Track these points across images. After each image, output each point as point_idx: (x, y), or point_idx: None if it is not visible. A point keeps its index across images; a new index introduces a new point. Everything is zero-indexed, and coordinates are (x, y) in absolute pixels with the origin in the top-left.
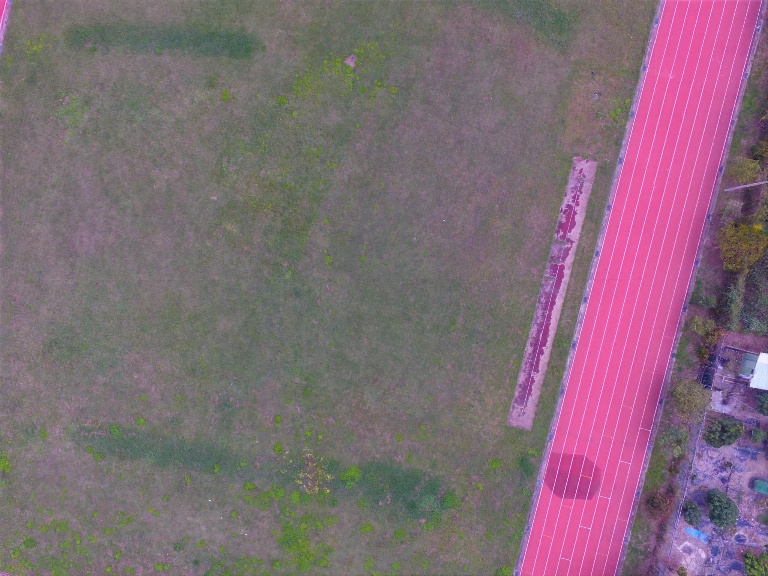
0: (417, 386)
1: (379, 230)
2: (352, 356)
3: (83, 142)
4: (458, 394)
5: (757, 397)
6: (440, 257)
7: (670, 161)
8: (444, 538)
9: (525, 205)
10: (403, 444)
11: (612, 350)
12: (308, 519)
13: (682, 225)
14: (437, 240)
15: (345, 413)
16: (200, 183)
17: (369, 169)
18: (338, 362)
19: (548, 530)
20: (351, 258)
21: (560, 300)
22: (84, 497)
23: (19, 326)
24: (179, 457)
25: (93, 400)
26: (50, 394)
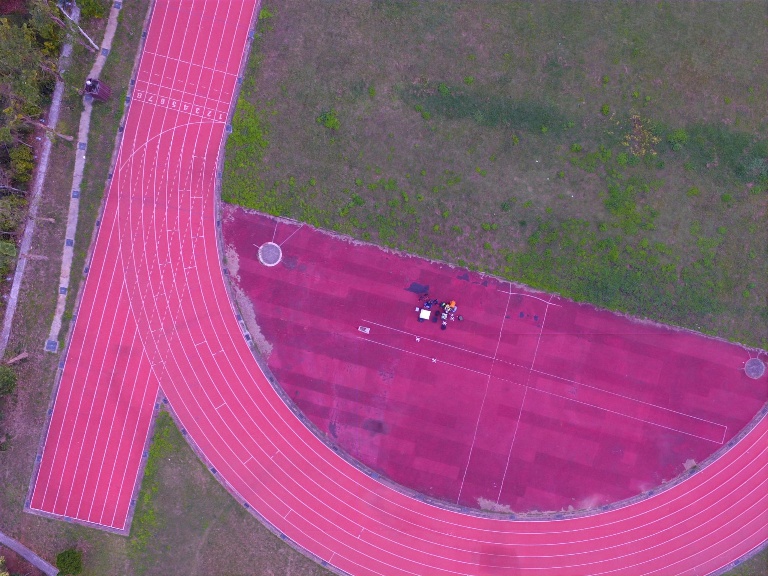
0: (745, 48)
1: None
2: (680, 17)
3: None
4: None
5: None
6: None
7: None
8: None
9: None
10: (730, 107)
11: None
12: (635, 181)
13: None
14: None
15: (672, 75)
16: None
17: None
18: (666, 23)
19: None
20: None
21: None
22: (412, 156)
23: None
24: (507, 116)
25: (422, 58)
26: (379, 51)
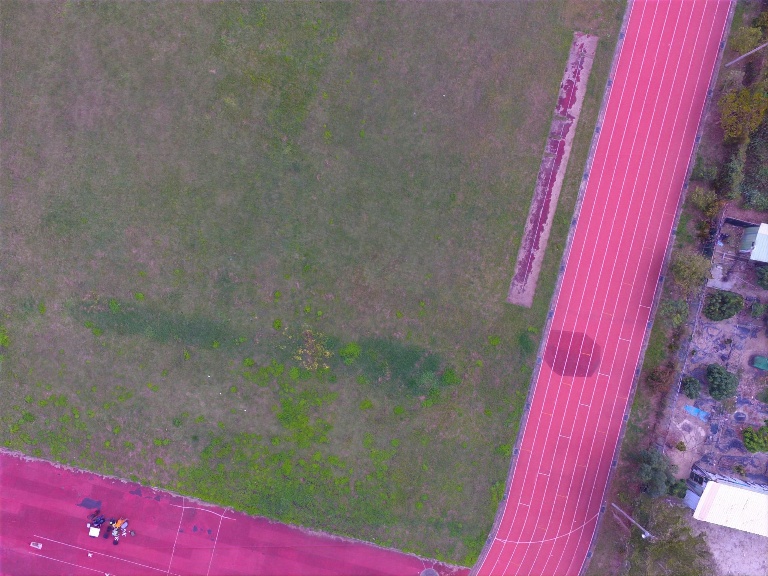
0: (417, 262)
1: (379, 105)
2: (351, 232)
3: (81, 13)
4: (458, 271)
5: (757, 270)
6: (440, 132)
7: (671, 36)
8: (443, 415)
9: (525, 80)
10: (402, 321)
11: (612, 227)
12: (307, 395)
13: (683, 101)
14: (437, 115)
15: (344, 289)
16: (199, 56)
17: (369, 43)
18: (337, 238)
19: (548, 407)
20: (351, 133)
21: (560, 176)
22: (83, 372)
23: (17, 199)
24: (178, 332)
25: (92, 274)
26: (48, 268)
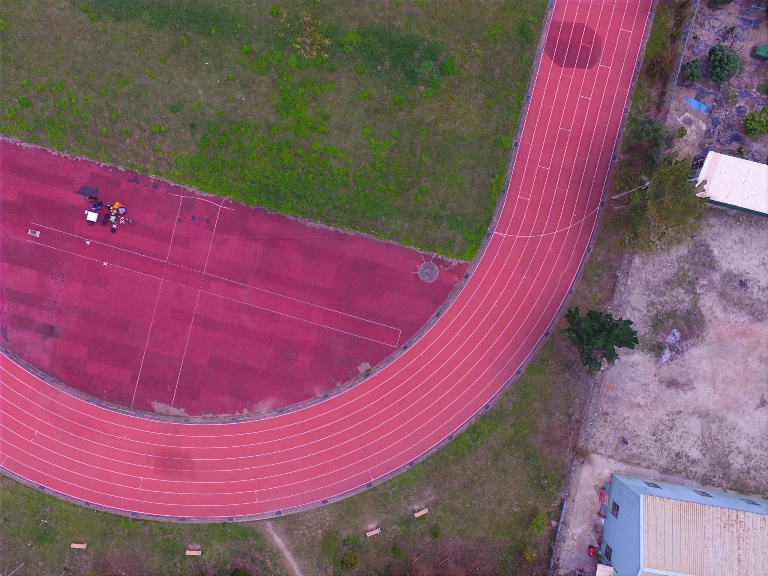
0: None
1: None
2: None
3: None
4: None
5: None
6: None
7: None
8: (443, 106)
9: None
10: (402, 9)
11: None
12: (306, 83)
13: None
14: None
15: None
16: None
17: None
18: None
19: (548, 99)
20: None
21: None
22: (79, 57)
23: None
24: (175, 18)
25: None
26: None
